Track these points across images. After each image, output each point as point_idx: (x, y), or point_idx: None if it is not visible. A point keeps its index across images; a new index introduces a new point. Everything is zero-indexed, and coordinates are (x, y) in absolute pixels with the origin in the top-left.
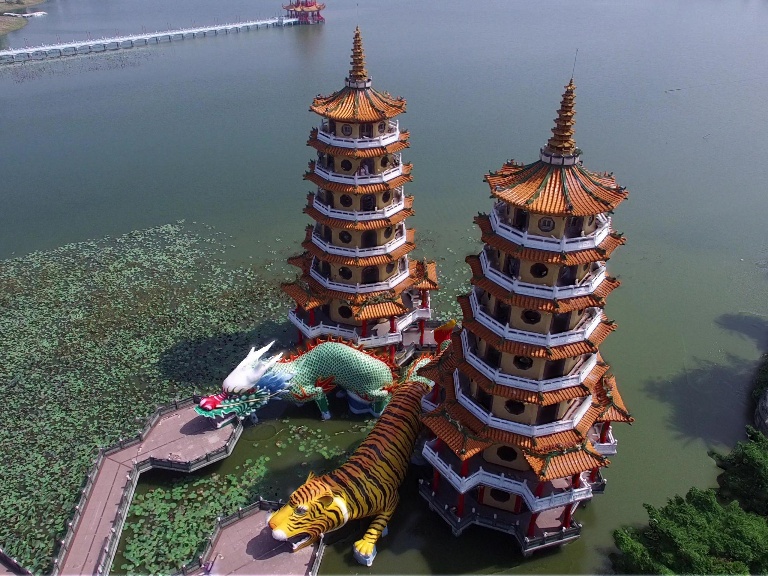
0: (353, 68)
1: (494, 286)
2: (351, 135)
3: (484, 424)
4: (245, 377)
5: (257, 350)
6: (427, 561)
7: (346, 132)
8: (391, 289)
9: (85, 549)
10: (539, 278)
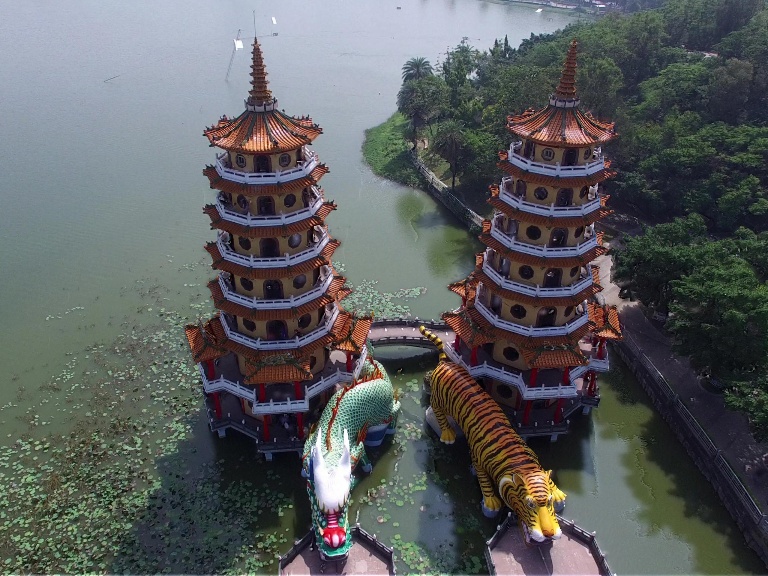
0: (259, 89)
1: (565, 220)
2: (291, 164)
3: (565, 335)
4: (343, 479)
5: (209, 487)
6: (572, 469)
7: (283, 163)
8: (341, 311)
9: None
10: (583, 198)
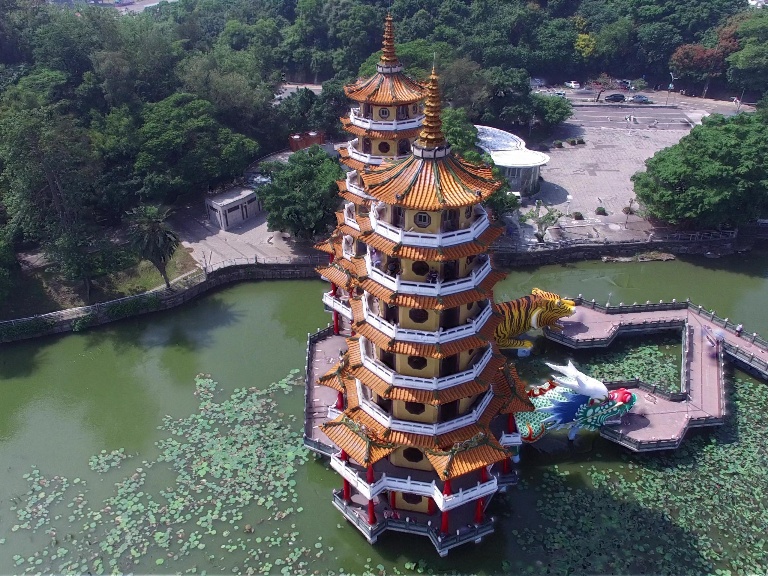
0: None
1: None
2: None
3: None
4: None
5: None
6: None
7: None
8: None
9: (706, 359)
10: None
